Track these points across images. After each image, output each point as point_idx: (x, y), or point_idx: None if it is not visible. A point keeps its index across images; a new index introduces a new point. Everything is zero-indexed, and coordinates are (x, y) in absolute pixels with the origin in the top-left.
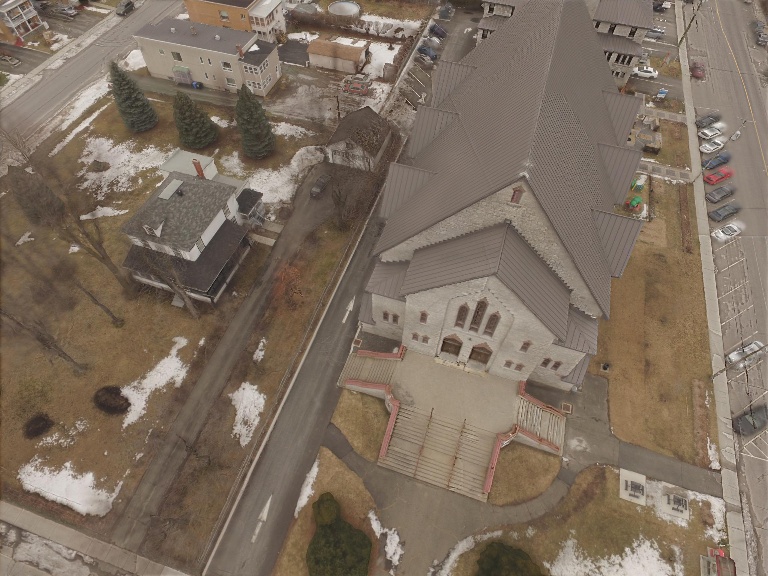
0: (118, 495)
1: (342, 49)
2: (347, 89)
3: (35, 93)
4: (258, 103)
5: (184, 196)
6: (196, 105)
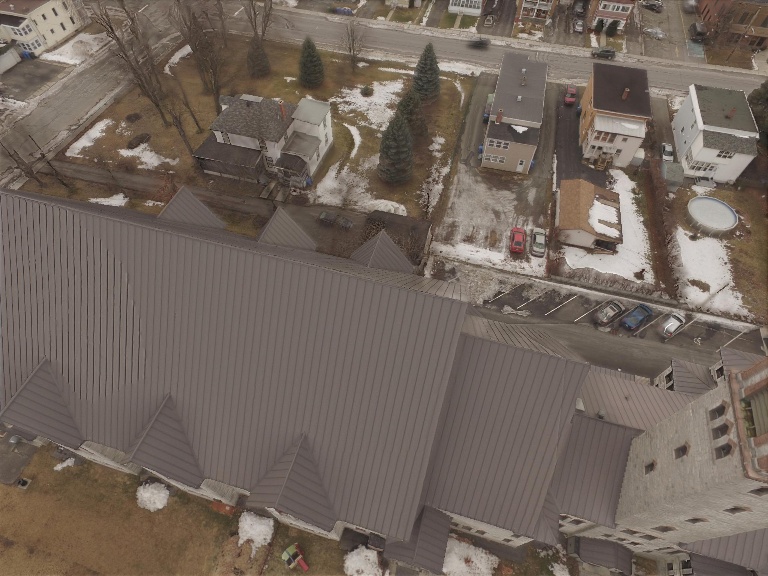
0: (75, 157)
1: (575, 209)
2: (513, 231)
3: (455, 43)
4: (400, 138)
5: (249, 108)
6: (415, 110)
